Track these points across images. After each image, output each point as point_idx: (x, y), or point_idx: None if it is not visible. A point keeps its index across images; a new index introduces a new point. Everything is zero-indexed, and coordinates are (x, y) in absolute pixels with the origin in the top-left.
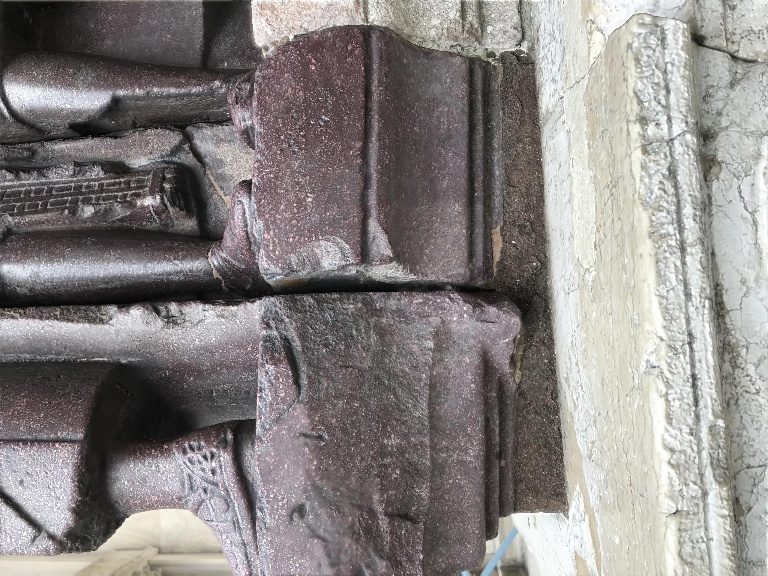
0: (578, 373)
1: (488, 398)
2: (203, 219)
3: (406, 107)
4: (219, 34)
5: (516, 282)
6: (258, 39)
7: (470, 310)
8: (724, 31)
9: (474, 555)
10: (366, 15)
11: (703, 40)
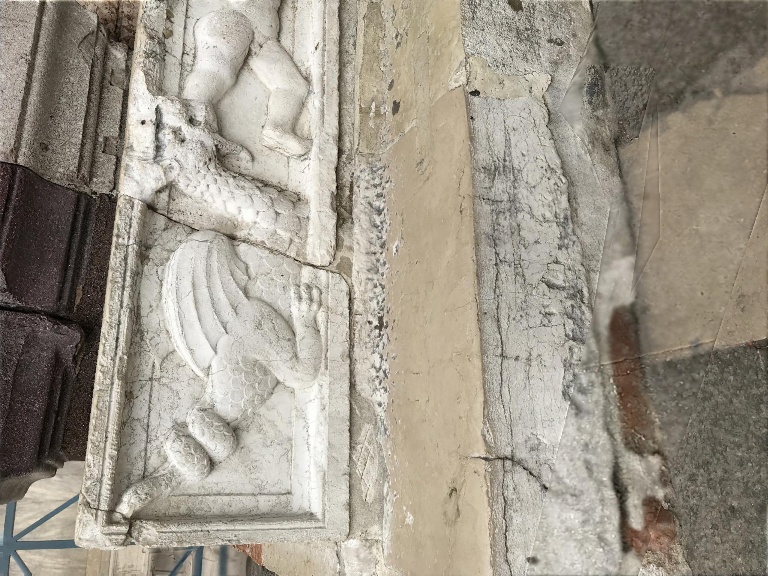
0: None
1: (56, 379)
2: None
3: (32, 211)
4: None
5: (86, 317)
6: None
7: (51, 326)
8: (167, 208)
9: (27, 464)
10: (16, 159)
11: (157, 210)
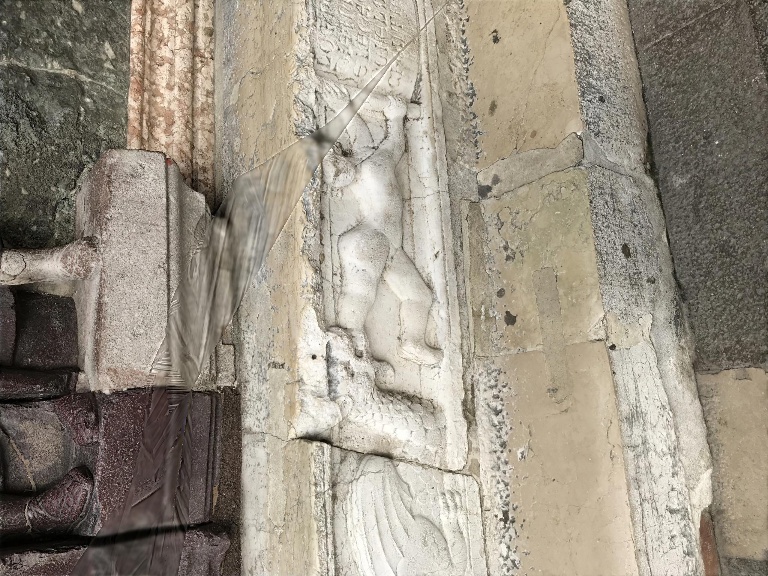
0: (263, 572)
1: None
2: (6, 477)
3: None
4: (23, 335)
5: (224, 517)
6: (103, 387)
7: (207, 540)
8: None
9: None
10: None
11: (332, 444)
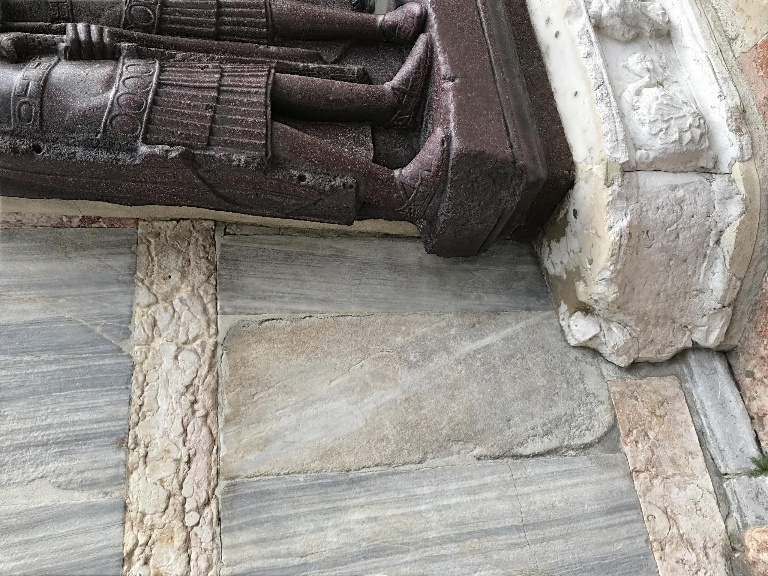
0: None
1: None
2: None
3: None
4: None
5: None
6: None
7: None
8: None
9: None
10: None
11: None
